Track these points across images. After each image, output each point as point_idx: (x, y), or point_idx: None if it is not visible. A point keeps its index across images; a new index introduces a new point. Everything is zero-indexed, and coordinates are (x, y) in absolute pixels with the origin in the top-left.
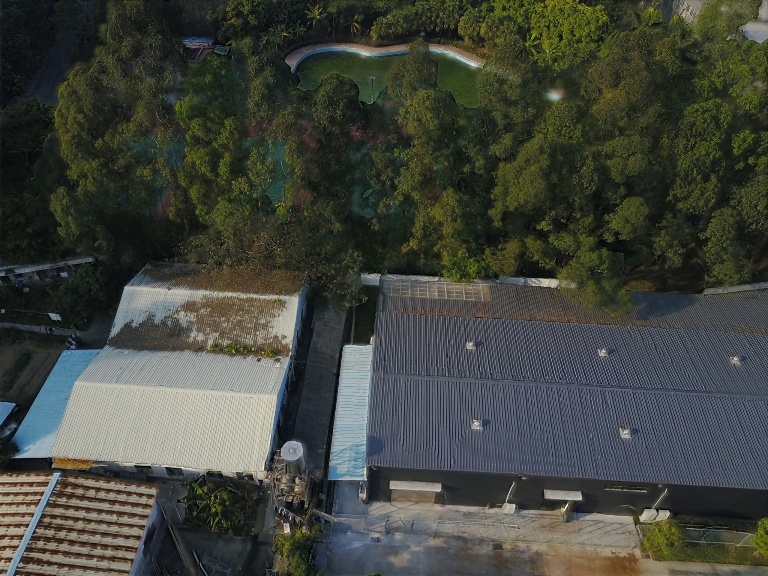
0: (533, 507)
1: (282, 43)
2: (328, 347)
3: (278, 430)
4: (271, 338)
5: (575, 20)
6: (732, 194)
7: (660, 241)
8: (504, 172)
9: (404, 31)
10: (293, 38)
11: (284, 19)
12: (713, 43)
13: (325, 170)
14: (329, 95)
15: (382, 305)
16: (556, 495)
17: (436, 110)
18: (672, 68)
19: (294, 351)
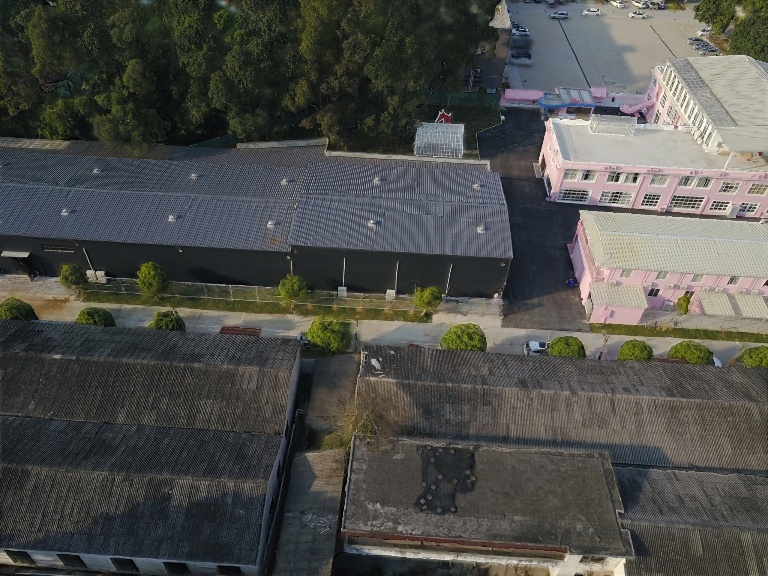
0: (14, 272)
1: None
2: None
3: None
4: None
5: None
6: None
7: (188, 102)
8: None
9: None
10: None
11: None
12: None
13: None
14: None
15: None
16: (10, 254)
17: None
18: None
19: None
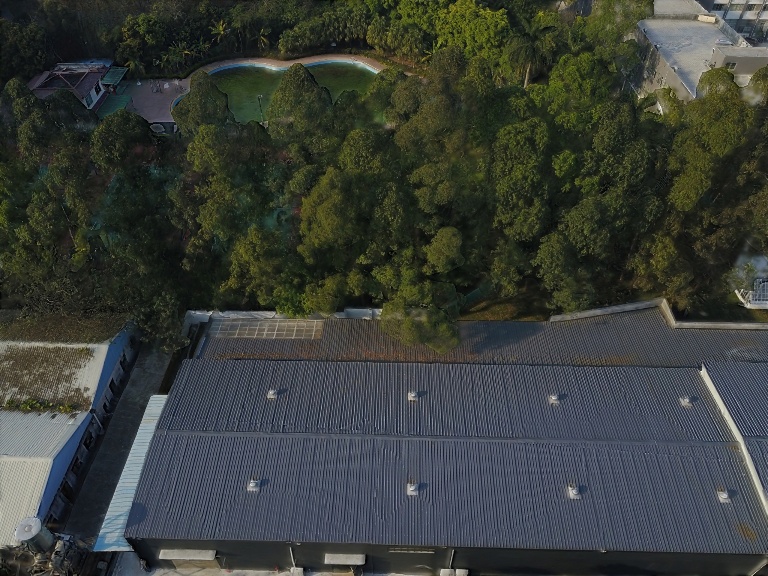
0: (326, 569)
1: (184, 61)
2: (141, 396)
3: (66, 493)
4: (73, 391)
5: (475, 26)
6: (560, 218)
7: (494, 269)
8: (305, 207)
9: (312, 43)
10: (196, 55)
11: (185, 36)
12: (603, 46)
13: (125, 211)
14: (102, 135)
15: (201, 348)
16: (337, 560)
17: (220, 146)
18: (481, 88)
19: (106, 402)
